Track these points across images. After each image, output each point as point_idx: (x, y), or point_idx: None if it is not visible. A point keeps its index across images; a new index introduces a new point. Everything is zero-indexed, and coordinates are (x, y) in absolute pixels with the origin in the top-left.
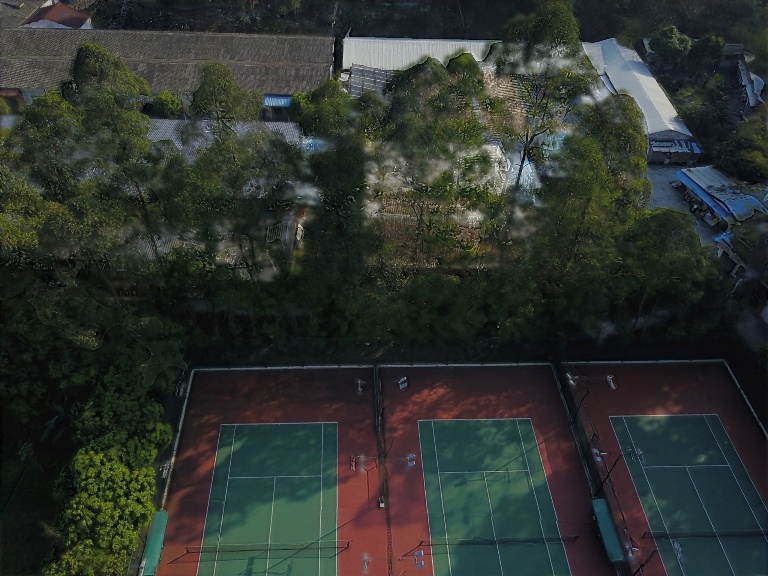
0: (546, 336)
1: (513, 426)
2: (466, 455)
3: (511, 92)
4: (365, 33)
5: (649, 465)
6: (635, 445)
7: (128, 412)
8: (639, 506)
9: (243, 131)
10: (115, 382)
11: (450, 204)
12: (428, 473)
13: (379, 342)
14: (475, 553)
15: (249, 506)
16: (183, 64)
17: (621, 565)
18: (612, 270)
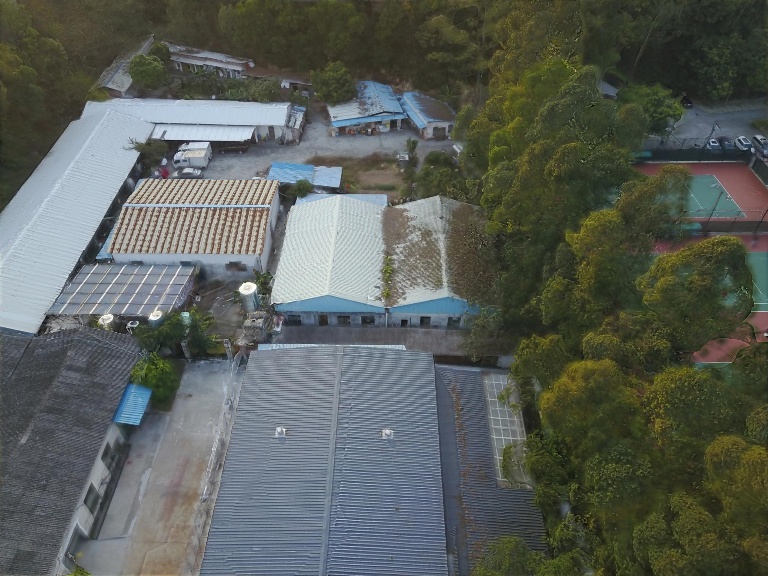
0: None
1: None
2: None
3: None
4: None
5: None
6: None
7: None
8: None
9: None
10: None
11: None
12: None
13: None
14: None
15: None
16: None
17: None
18: None
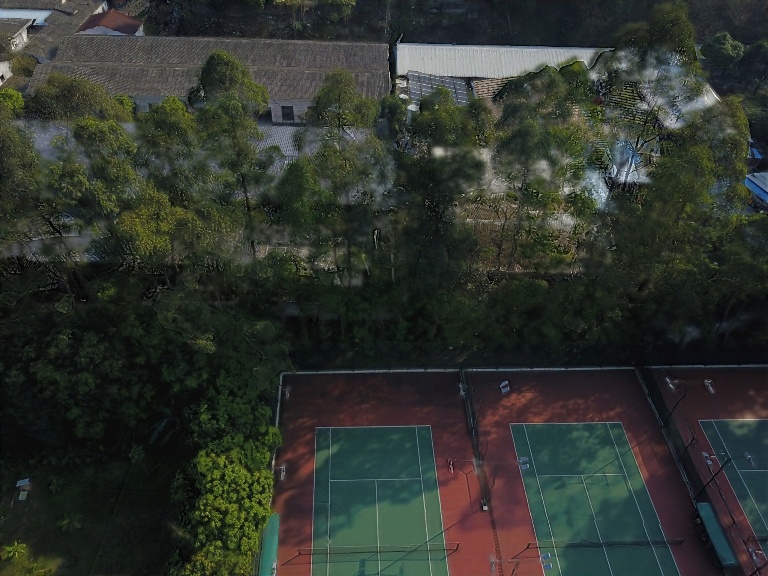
0: (630, 340)
1: (605, 430)
2: (562, 458)
3: (623, 99)
4: (414, 39)
5: (744, 469)
6: (728, 449)
7: (242, 415)
8: (740, 509)
9: (362, 138)
10: (228, 385)
11: (551, 210)
12: (526, 476)
13: (462, 346)
14: (583, 556)
15: (354, 508)
16: None
17: (733, 568)
18: (708, 275)
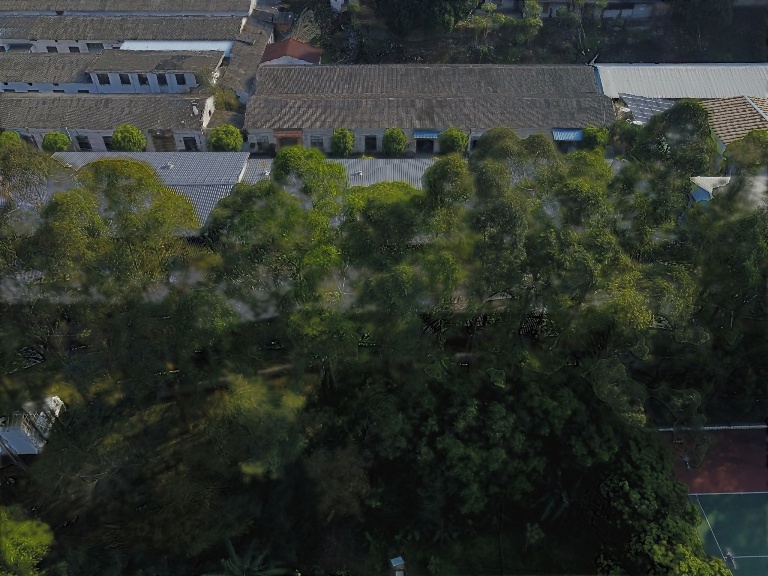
0: None
1: None
2: None
3: None
4: (600, 59)
5: None
6: None
7: (668, 493)
8: None
9: None
10: (646, 459)
11: None
12: None
13: None
14: None
15: None
16: (460, 99)
17: None
18: None
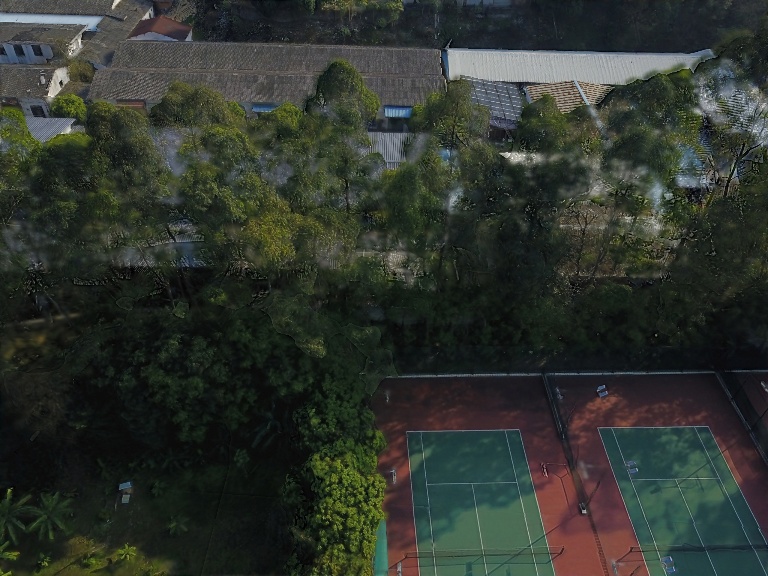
0: (711, 345)
1: (693, 434)
2: (654, 462)
3: (730, 107)
4: (461, 44)
5: None
6: None
7: (350, 419)
8: None
9: (474, 145)
10: (334, 390)
11: (648, 215)
12: (621, 480)
13: (542, 350)
14: (686, 559)
15: (454, 512)
16: (301, 76)
17: None
18: None
